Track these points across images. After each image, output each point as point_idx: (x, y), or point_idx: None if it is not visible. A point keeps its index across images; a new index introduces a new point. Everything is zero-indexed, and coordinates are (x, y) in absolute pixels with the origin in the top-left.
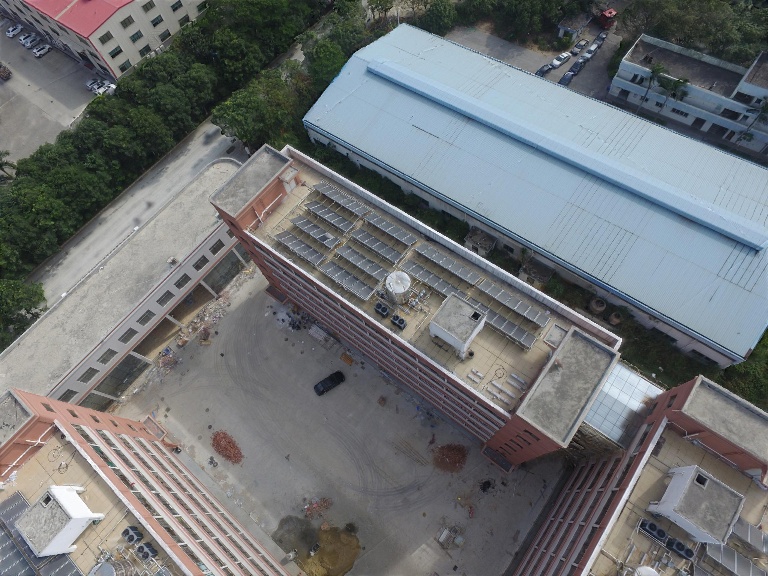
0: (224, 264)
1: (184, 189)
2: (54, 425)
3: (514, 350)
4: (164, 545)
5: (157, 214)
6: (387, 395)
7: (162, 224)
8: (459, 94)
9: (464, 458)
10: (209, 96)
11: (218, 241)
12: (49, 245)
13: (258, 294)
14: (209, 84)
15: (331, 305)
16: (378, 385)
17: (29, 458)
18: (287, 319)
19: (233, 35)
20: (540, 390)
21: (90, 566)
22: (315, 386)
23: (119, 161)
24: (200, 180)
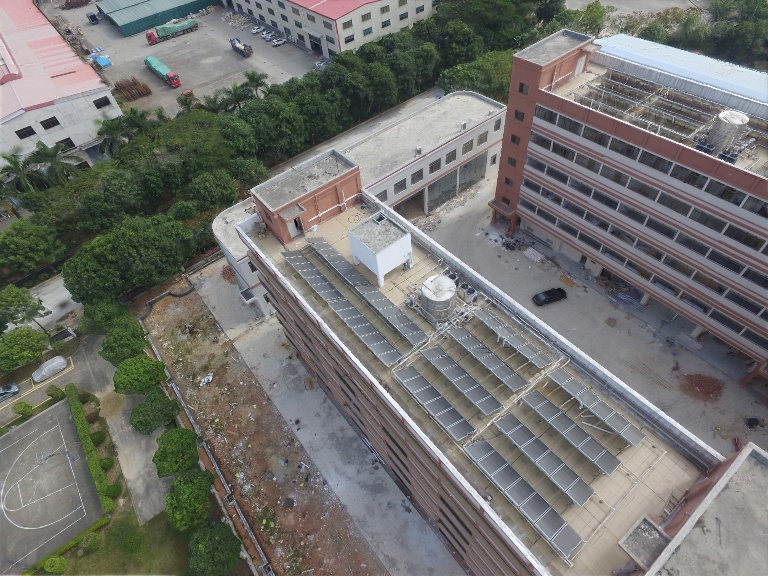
0: (446, 181)
1: (427, 108)
2: (359, 193)
3: None
4: (492, 285)
5: (401, 121)
6: (616, 318)
7: (405, 129)
8: (698, 71)
9: (719, 390)
10: (430, 72)
11: (454, 151)
12: (280, 151)
13: (469, 218)
14: (434, 61)
15: (618, 167)
16: (605, 308)
17: (329, 218)
18: (500, 240)
19: (465, 25)
20: None
21: (400, 300)
22: (535, 295)
23: (350, 102)
24: (441, 104)
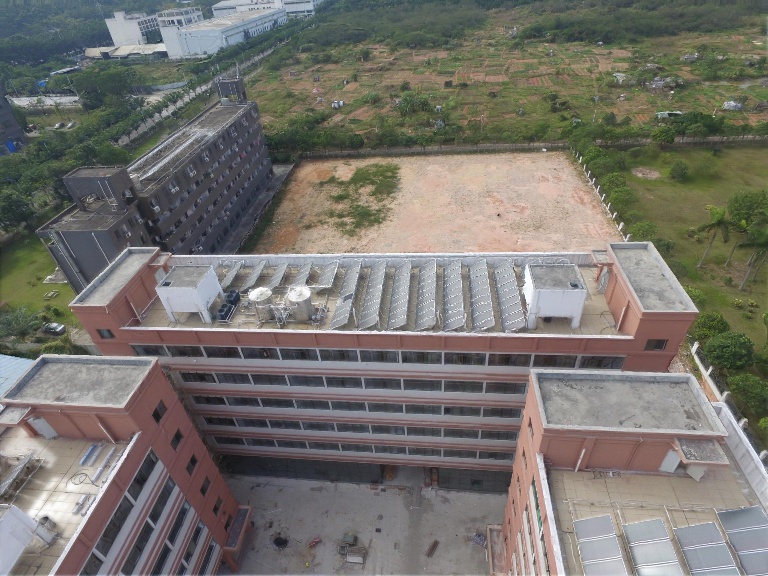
0: None
1: None
2: None
3: (42, 477)
4: None
5: None
6: None
7: None
8: None
9: None
10: None
11: None
12: None
13: None
14: None
15: None
16: None
17: None
18: None
19: None
20: (92, 403)
21: None
22: None
23: None
24: None
